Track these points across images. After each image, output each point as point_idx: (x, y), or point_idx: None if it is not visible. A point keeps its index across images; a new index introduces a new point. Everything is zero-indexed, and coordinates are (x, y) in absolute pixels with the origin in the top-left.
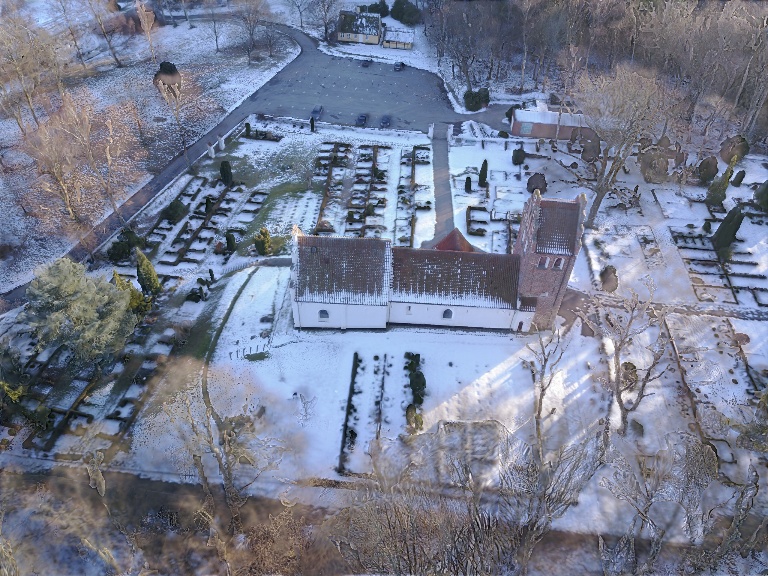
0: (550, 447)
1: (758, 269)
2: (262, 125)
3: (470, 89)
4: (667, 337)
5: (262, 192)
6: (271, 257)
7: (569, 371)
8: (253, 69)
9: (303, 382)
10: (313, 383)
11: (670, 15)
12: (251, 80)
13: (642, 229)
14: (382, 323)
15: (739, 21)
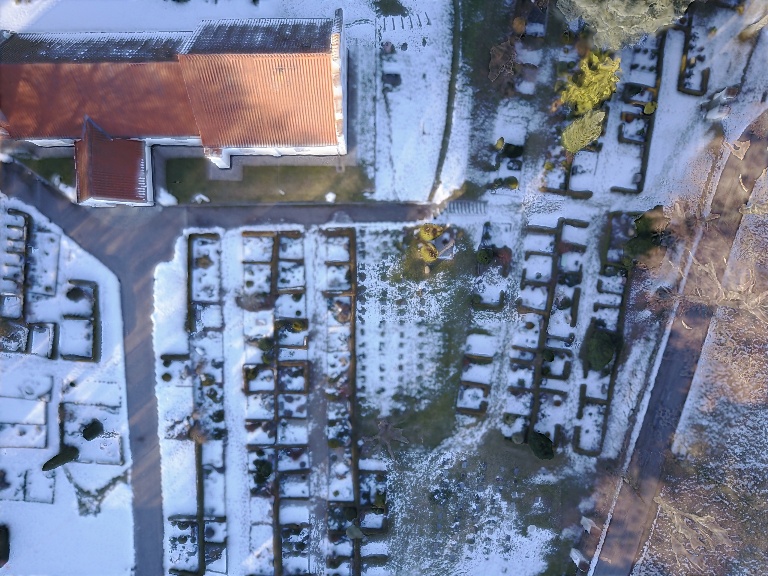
0: None
1: None
2: None
3: None
4: None
5: (468, 413)
6: (415, 224)
7: None
8: None
9: None
10: None
11: None
12: None
13: None
14: None
15: None
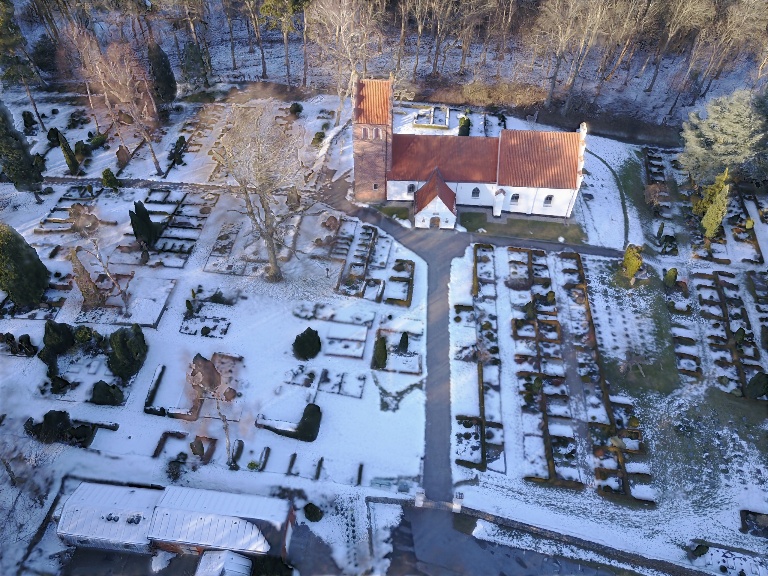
0: None
1: None
2: None
3: None
4: None
5: (689, 371)
6: (618, 259)
7: None
8: None
9: None
10: None
11: None
12: None
13: (216, 265)
14: None
15: None
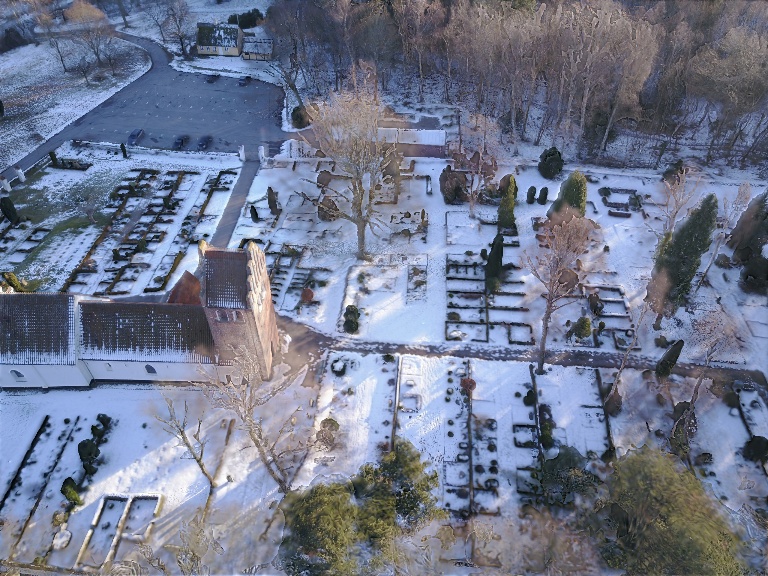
0: (215, 521)
1: (525, 300)
2: (75, 152)
3: (301, 104)
4: (395, 384)
5: (44, 228)
6: None
7: (270, 429)
8: (90, 90)
9: None
10: None
11: (474, 23)
12: (82, 103)
13: (417, 258)
14: (83, 381)
15: (529, 29)
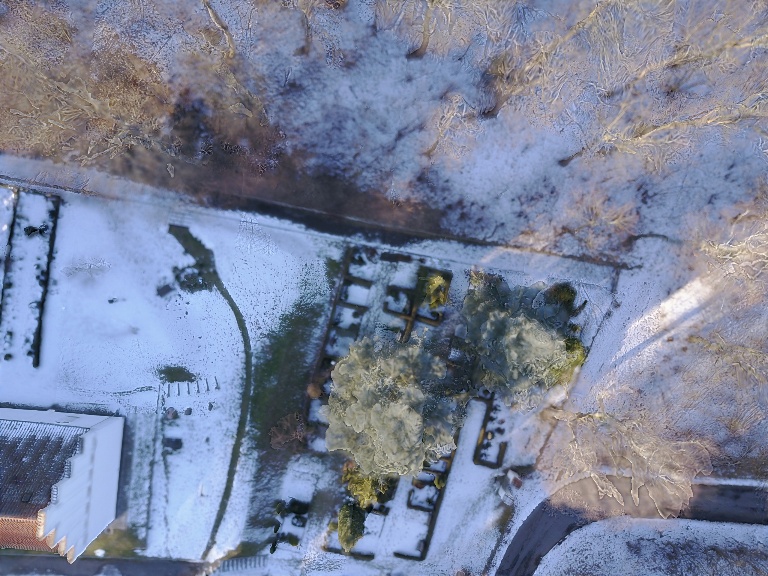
0: None
1: None
2: None
3: None
4: None
5: None
6: None
7: None
8: None
9: (107, 326)
10: (94, 323)
11: None
12: None
13: None
14: None
15: None
